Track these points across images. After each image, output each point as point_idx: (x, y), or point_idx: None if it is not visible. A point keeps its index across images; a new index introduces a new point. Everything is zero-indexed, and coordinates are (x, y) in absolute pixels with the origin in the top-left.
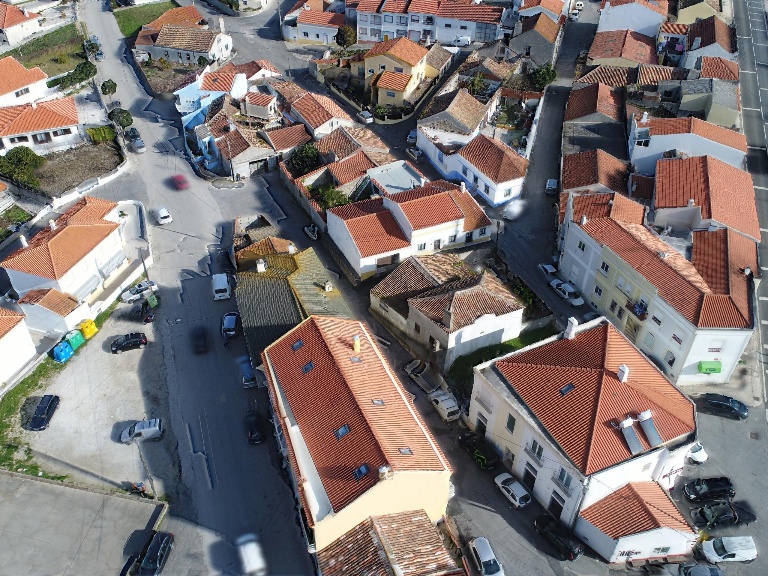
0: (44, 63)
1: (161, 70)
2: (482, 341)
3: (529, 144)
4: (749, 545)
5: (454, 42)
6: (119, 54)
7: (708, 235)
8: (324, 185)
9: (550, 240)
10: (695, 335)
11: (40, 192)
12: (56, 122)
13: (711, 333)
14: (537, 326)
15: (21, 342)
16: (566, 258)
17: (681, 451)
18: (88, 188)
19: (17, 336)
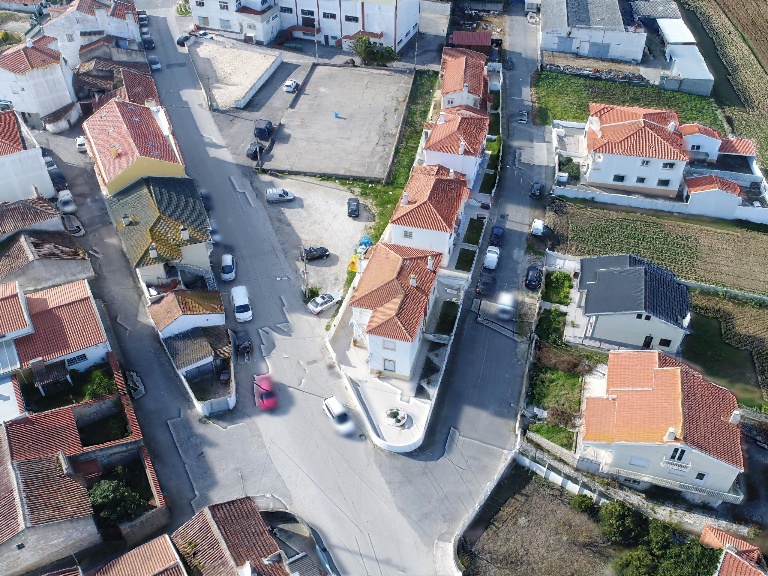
0: None
1: None
2: None
3: None
4: None
5: None
6: None
7: None
8: None
9: None
10: None
11: (569, 502)
12: None
13: None
14: None
15: None
16: None
17: None
18: None
19: None
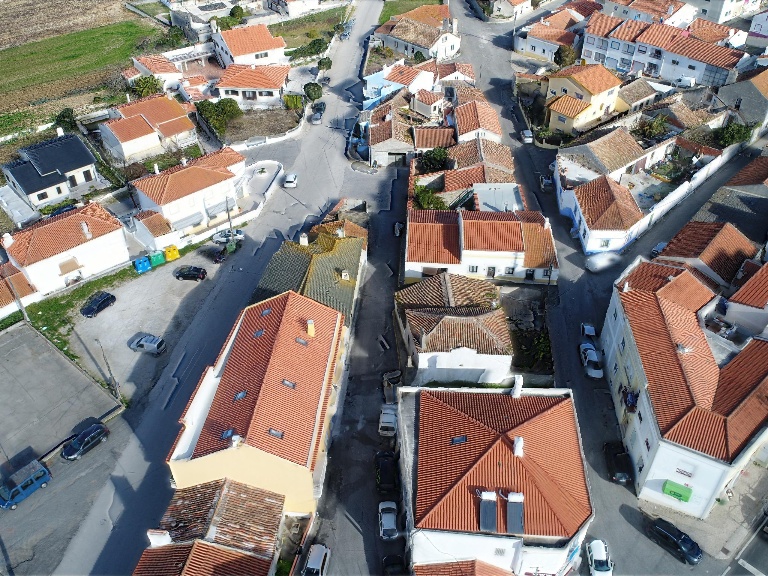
0: (298, 35)
1: (385, 58)
2: (459, 374)
3: (663, 200)
4: None
5: (675, 81)
6: (362, 38)
7: (766, 347)
8: (438, 189)
9: None
10: (658, 445)
11: (223, 138)
12: (263, 84)
13: (678, 450)
14: (528, 380)
15: (117, 247)
16: (605, 324)
17: (540, 551)
18: (256, 144)
19: (113, 241)
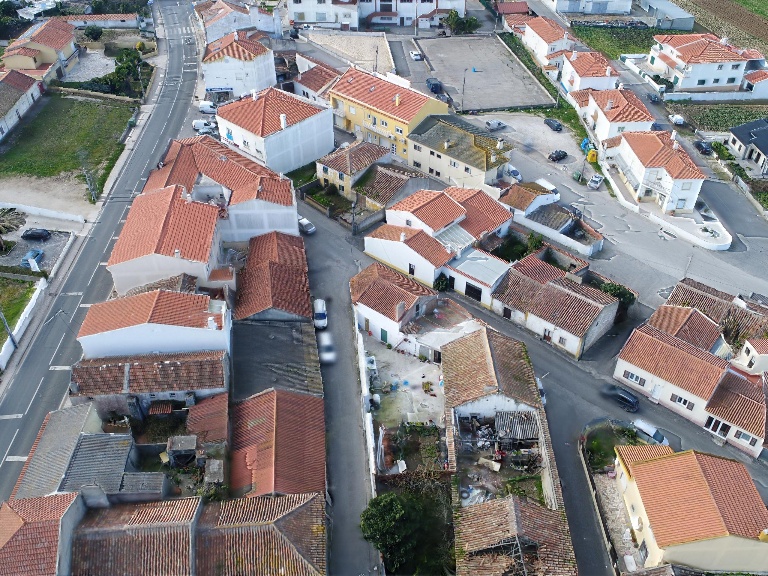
0: None
1: None
2: None
3: (362, 347)
4: (197, 120)
5: None
6: None
7: None
8: None
9: (311, 260)
10: None
11: None
12: None
13: None
14: None
15: None
16: None
17: None
18: None
19: None
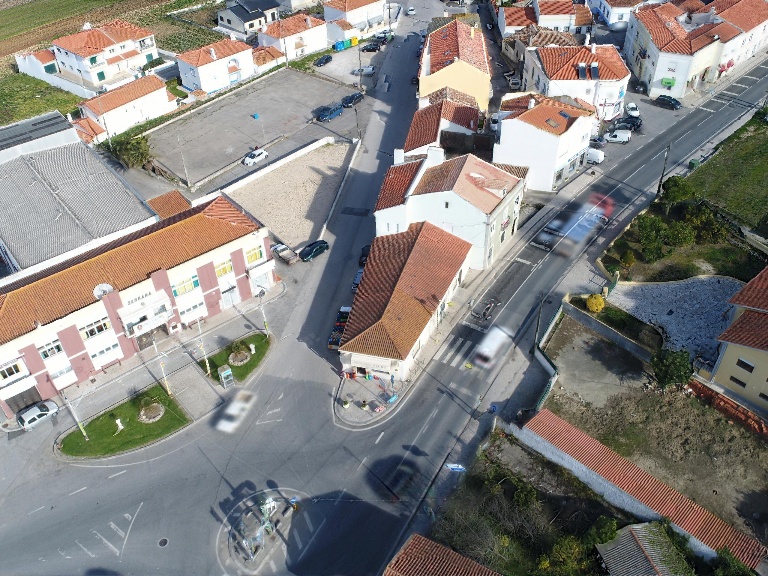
0: None
1: None
2: None
3: None
4: (626, 132)
5: None
6: None
7: (711, 24)
8: None
9: None
10: (659, 56)
11: None
12: None
13: (668, 56)
14: None
15: (322, 37)
16: (626, 39)
17: (608, 85)
18: None
19: (321, 32)
